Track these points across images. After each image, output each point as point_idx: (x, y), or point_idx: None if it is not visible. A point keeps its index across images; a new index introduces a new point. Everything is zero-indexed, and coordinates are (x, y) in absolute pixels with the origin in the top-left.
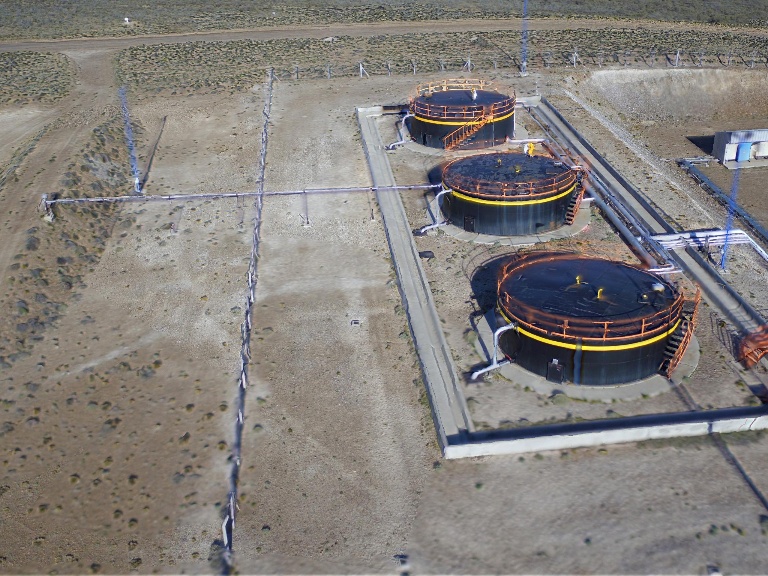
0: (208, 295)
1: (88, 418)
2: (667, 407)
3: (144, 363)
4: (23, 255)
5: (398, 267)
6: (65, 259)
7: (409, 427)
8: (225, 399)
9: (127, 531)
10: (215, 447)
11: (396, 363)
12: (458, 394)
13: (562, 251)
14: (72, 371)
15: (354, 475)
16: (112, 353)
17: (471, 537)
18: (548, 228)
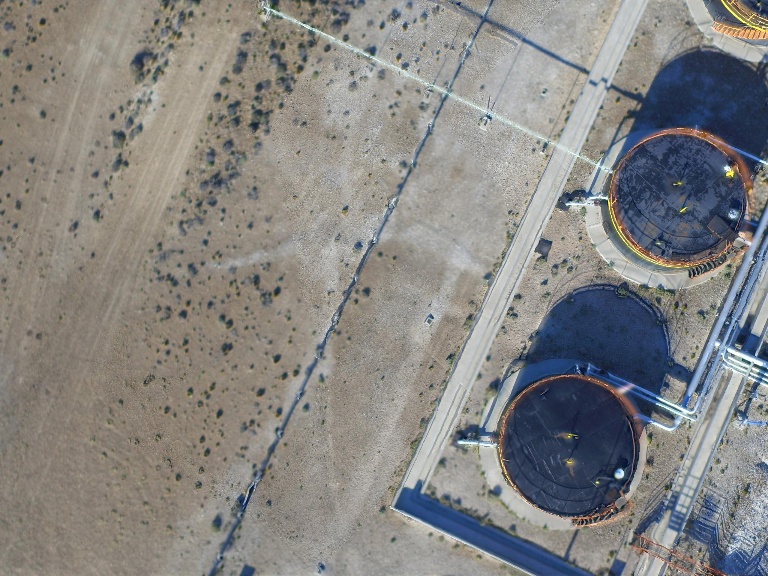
0: (350, 207)
1: (215, 332)
2: (550, 544)
3: (269, 285)
4: (227, 81)
5: (502, 266)
6: (263, 85)
7: (390, 464)
8: (301, 363)
9: (203, 457)
10: (274, 413)
11: (425, 390)
12: (438, 452)
13: (652, 310)
14: (222, 265)
15: (336, 487)
16: (254, 256)
17: (363, 575)
18: (668, 271)
